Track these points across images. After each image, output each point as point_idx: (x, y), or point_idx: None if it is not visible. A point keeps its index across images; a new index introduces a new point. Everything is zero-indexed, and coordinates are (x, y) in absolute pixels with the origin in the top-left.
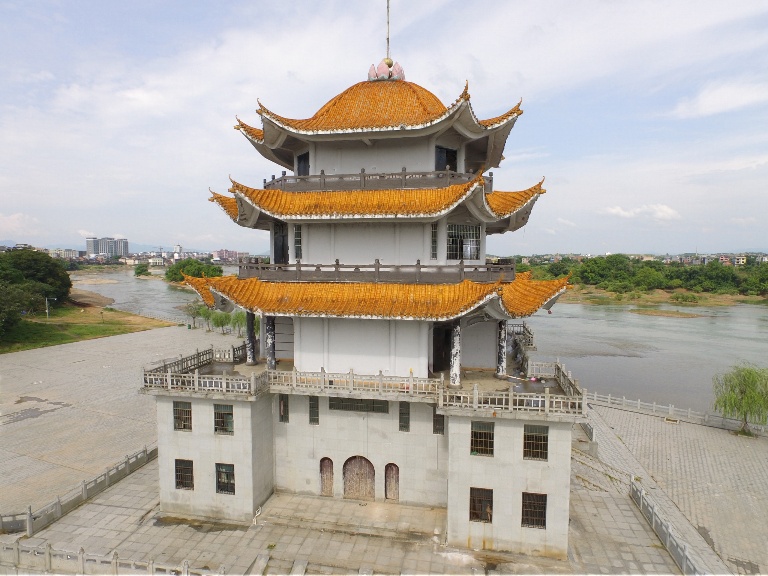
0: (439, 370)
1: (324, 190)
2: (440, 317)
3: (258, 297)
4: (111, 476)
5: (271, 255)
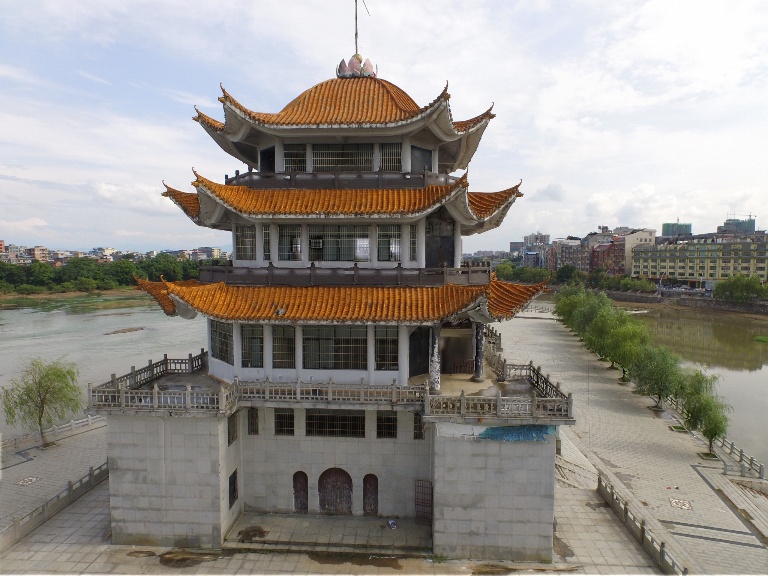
0: None
1: None
2: None
3: None
4: None
5: (424, 257)
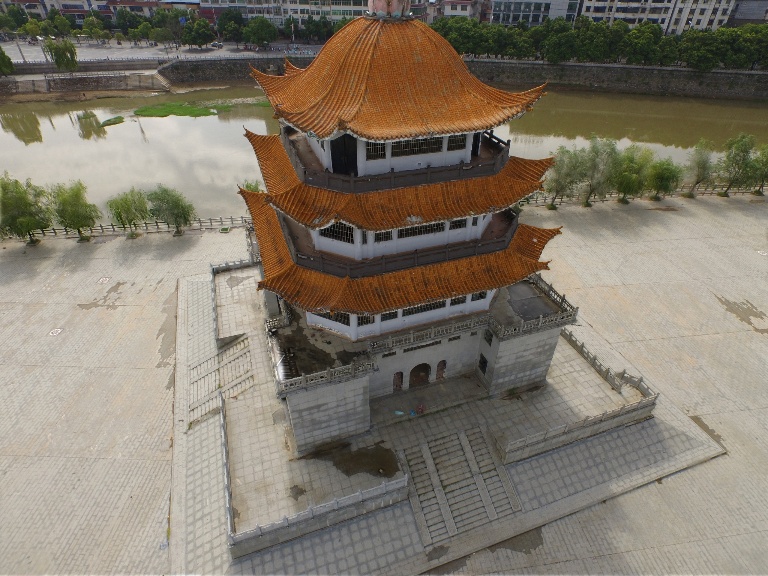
0: None
1: None
2: None
3: None
4: None
5: None
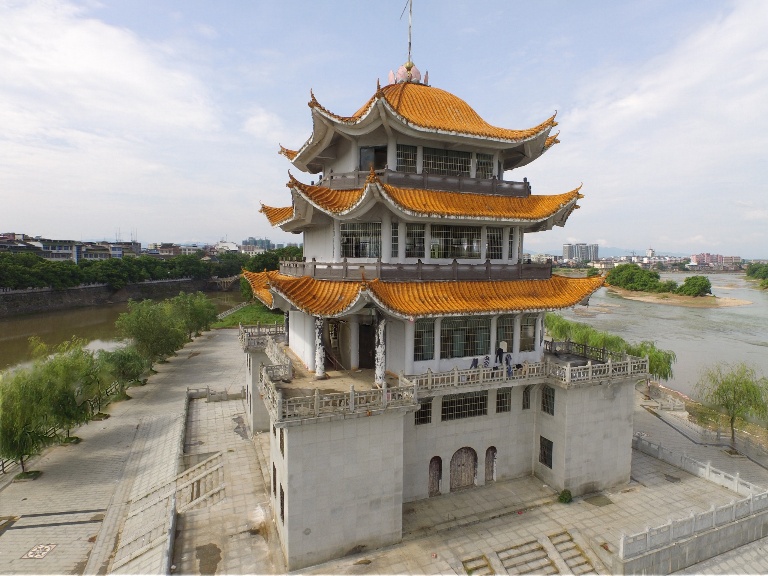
0: (364, 367)
1: None
2: (270, 306)
3: None
4: None
5: None
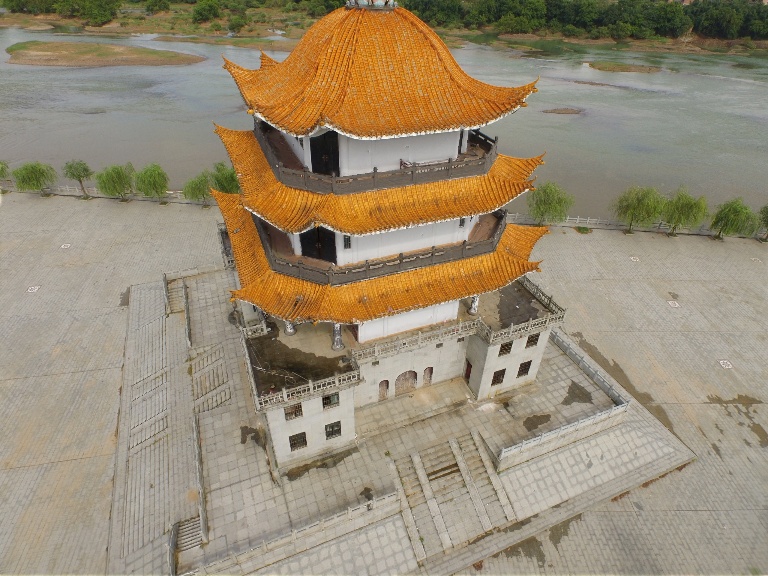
0: None
1: (379, 189)
2: None
3: (342, 305)
4: None
5: (296, 237)
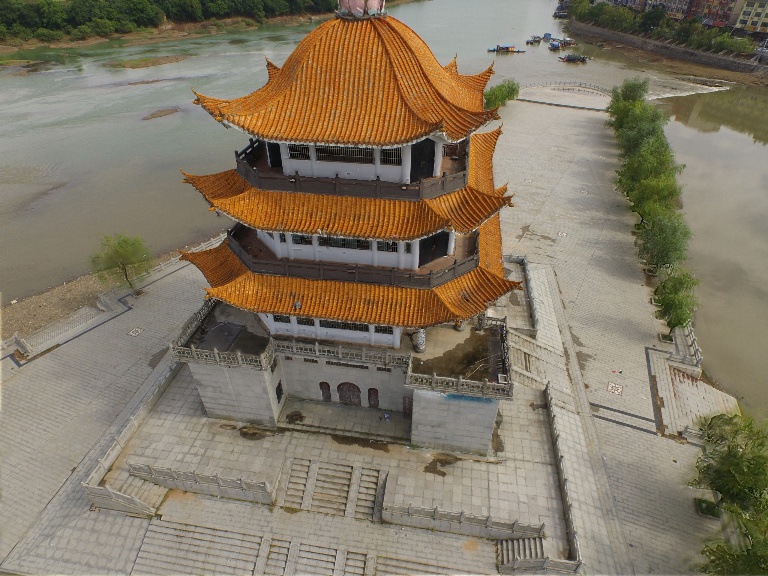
0: None
1: None
2: None
3: None
4: (457, 516)
5: (418, 251)
